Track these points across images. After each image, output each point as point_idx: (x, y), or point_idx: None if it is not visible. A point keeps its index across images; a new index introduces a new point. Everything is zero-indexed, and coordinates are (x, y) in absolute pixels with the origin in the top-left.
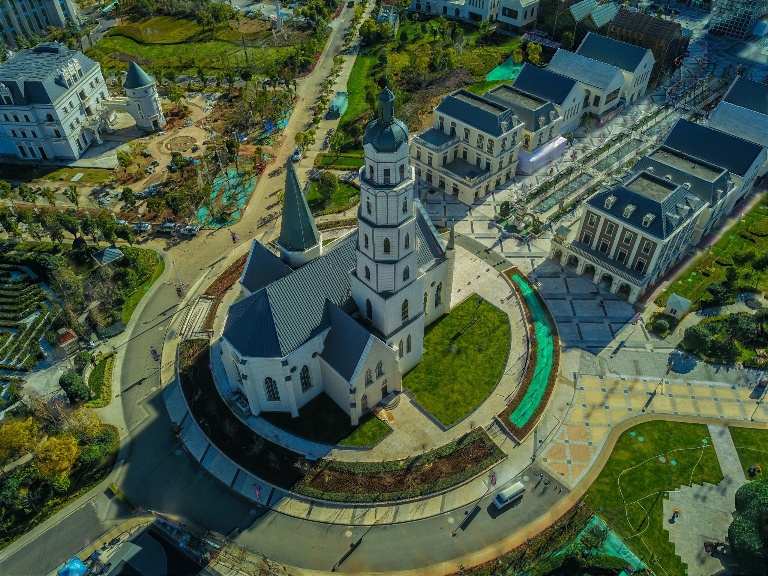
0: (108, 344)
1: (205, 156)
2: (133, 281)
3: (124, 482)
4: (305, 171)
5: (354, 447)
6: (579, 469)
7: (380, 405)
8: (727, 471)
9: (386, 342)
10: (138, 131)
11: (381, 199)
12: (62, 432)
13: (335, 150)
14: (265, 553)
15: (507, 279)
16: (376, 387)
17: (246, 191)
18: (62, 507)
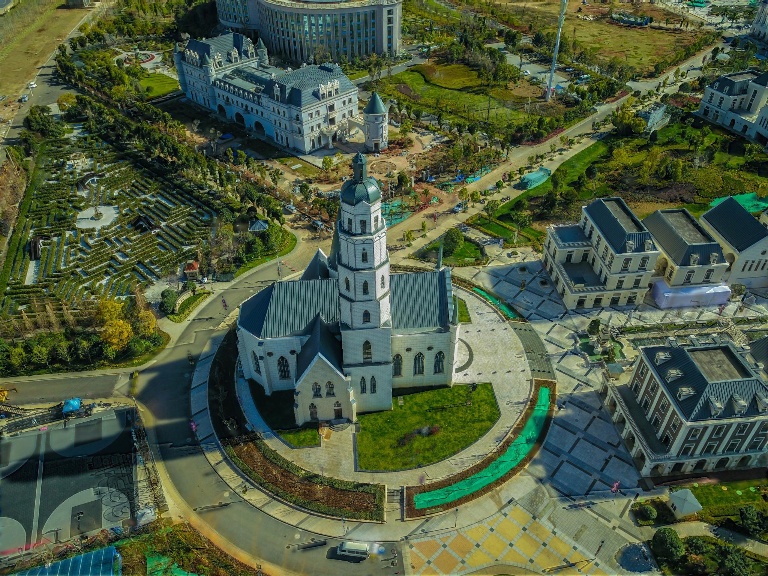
0: (214, 285)
1: (391, 183)
2: (258, 250)
3: (145, 374)
4: (454, 223)
5: (283, 439)
6: (431, 573)
7: (329, 422)
8: None
9: (344, 370)
10: (363, 148)
11: (343, 242)
12: (138, 323)
13: (488, 214)
14: (171, 469)
15: (532, 387)
16: (326, 404)
17: (395, 220)
18: (105, 368)
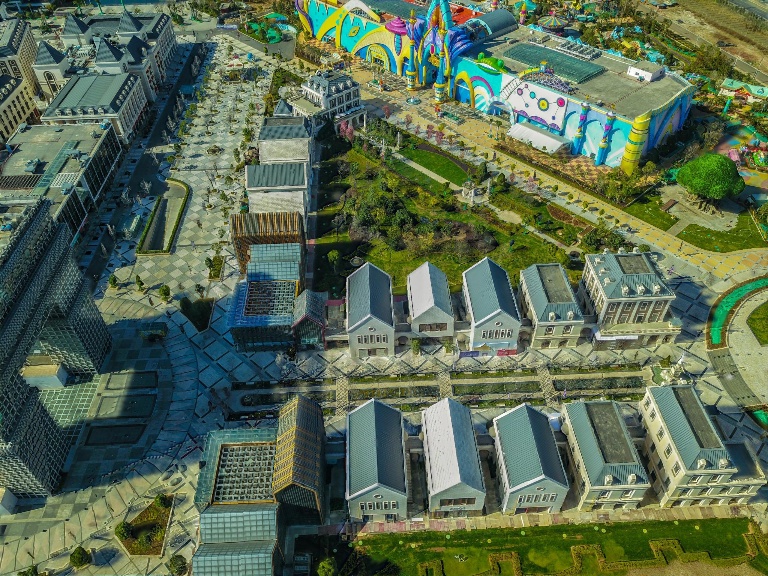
0: None
1: None
2: None
3: None
4: None
5: None
6: (759, 254)
7: None
8: (686, 224)
9: None
10: None
11: None
12: None
13: None
14: None
15: None
16: None
17: None
18: None
